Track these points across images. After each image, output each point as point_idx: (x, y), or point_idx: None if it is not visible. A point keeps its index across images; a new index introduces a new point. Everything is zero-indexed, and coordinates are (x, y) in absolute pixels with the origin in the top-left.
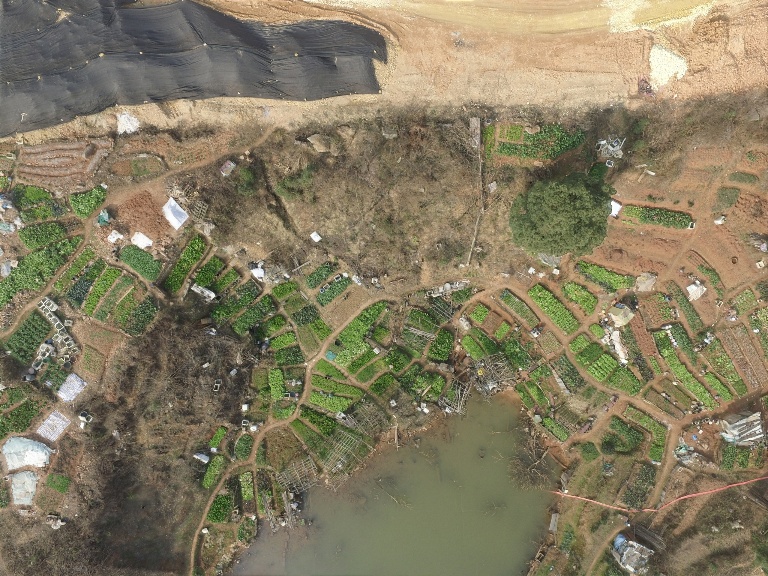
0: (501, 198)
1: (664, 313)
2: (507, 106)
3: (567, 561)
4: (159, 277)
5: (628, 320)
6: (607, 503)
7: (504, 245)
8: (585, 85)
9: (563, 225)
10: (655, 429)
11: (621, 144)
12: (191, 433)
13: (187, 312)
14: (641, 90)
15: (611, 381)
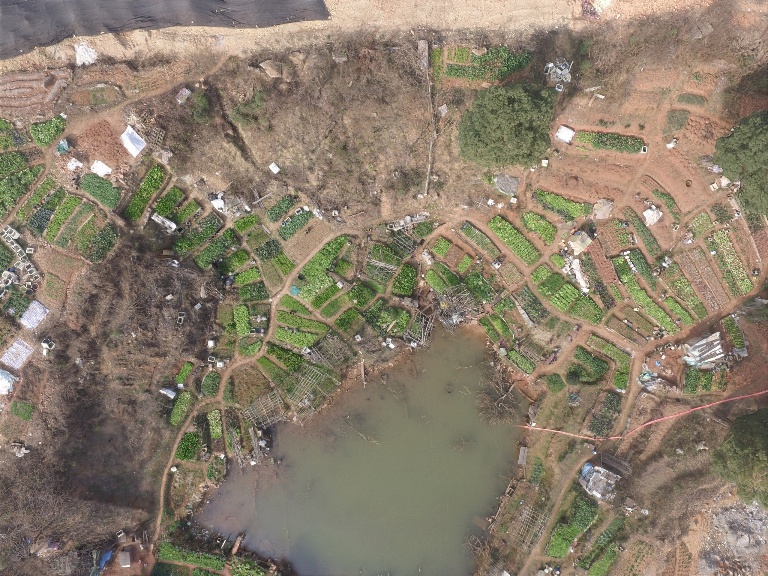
0: (453, 122)
1: (622, 239)
2: (454, 29)
3: (537, 494)
4: (119, 205)
5: (586, 246)
6: (574, 433)
7: (461, 174)
8: (529, 7)
9: (504, 128)
10: (619, 357)
11: (569, 67)
12: (156, 367)
13: (148, 242)
14: (585, 12)
15: (573, 310)
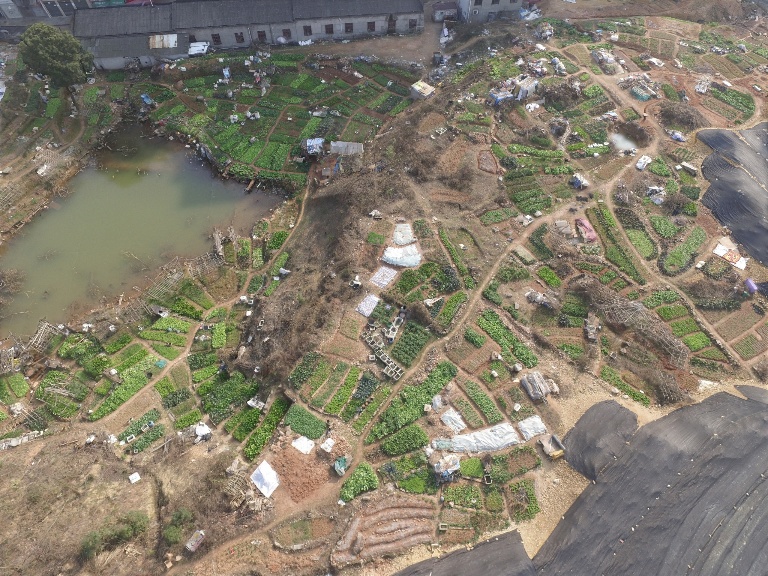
0: None
1: None
2: None
3: None
4: None
5: None
6: None
7: None
8: None
9: None
10: None
11: None
12: None
13: None
14: None
15: None
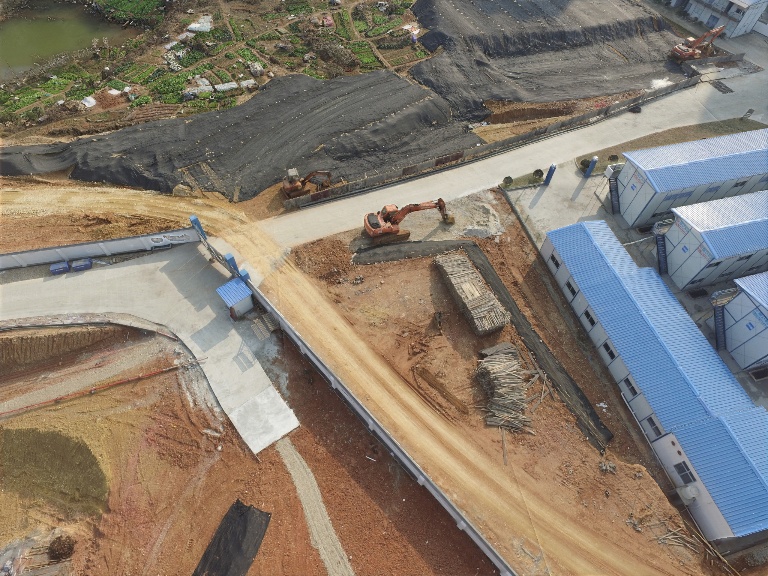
0: None
1: None
2: None
3: None
4: None
5: None
6: None
7: None
8: None
9: None
10: None
11: None
12: None
13: None
14: None
15: None
